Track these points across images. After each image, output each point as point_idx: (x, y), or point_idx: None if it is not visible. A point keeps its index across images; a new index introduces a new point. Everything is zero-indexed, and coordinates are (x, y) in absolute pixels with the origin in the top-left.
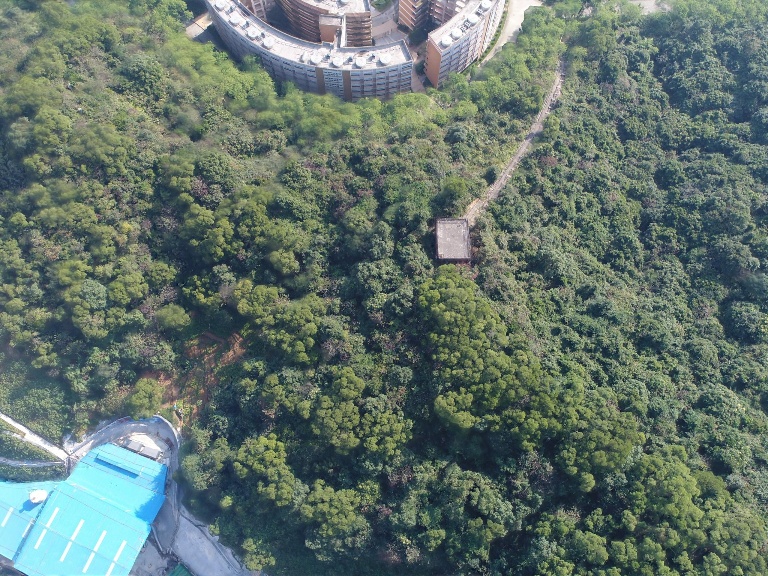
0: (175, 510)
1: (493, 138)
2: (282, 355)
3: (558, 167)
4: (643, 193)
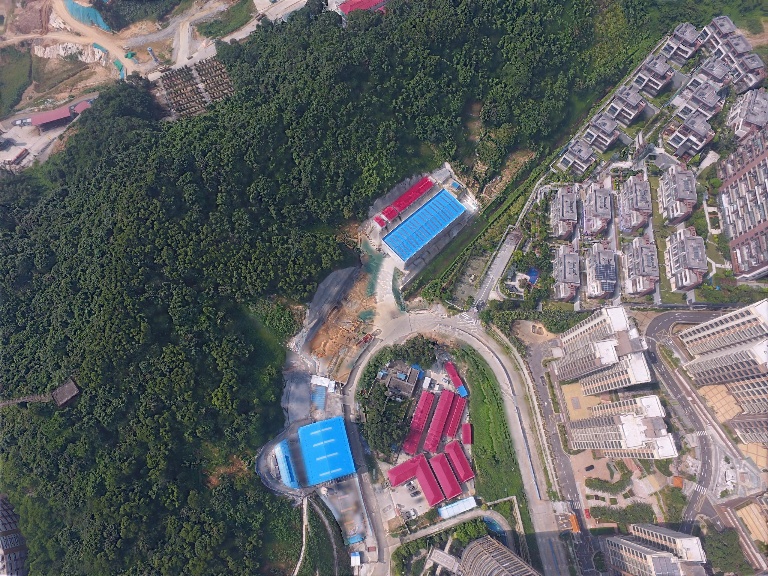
0: (290, 428)
1: (4, 423)
2: (177, 429)
3: (4, 380)
4: (3, 339)
